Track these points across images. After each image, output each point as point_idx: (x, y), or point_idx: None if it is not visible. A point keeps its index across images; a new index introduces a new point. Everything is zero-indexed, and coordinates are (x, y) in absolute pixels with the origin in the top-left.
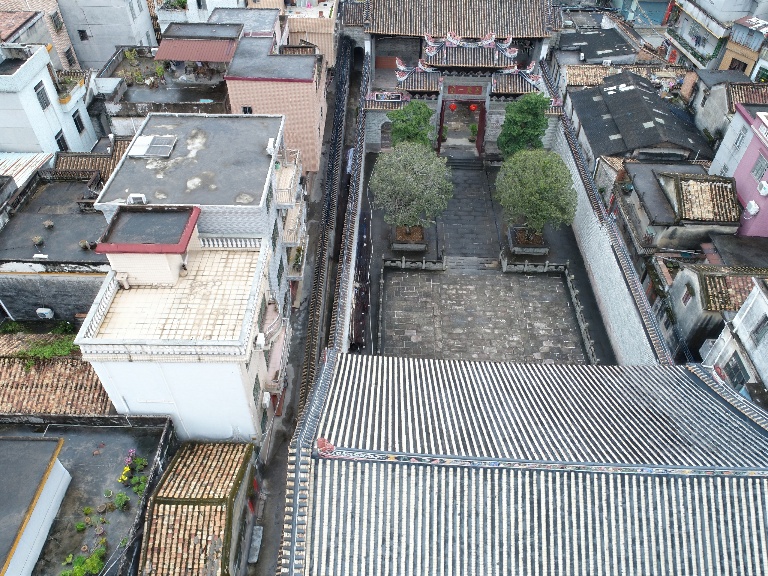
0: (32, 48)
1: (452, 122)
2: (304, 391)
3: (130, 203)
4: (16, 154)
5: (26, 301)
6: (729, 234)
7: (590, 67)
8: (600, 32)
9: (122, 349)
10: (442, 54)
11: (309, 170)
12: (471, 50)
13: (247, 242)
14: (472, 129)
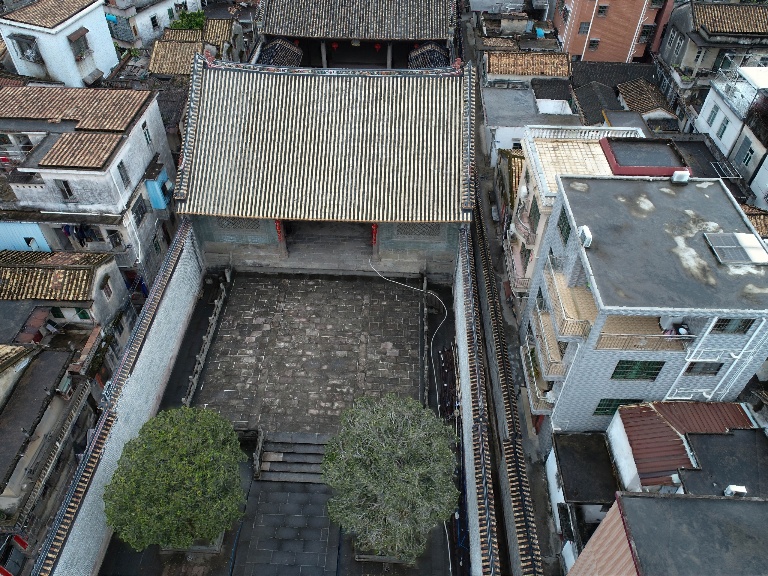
0: None
1: None
2: None
3: None
4: None
5: None
6: None
7: None
8: None
9: (608, 135)
10: None
11: None
12: None
13: None
14: None
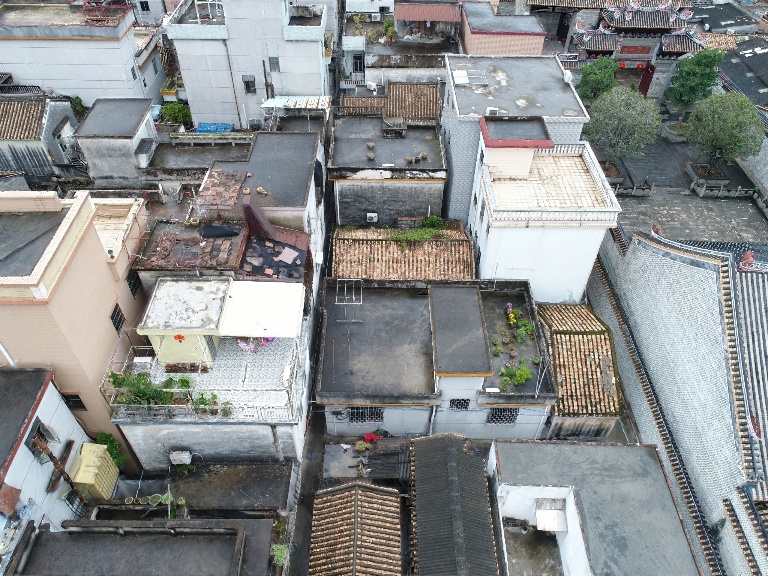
0: (315, 7)
1: None
2: (603, 272)
3: None
4: (301, 97)
5: (358, 207)
6: None
7: (721, 35)
8: (717, 6)
9: (525, 216)
10: (624, 17)
11: None
12: (649, 14)
13: (569, 148)
14: (631, 87)
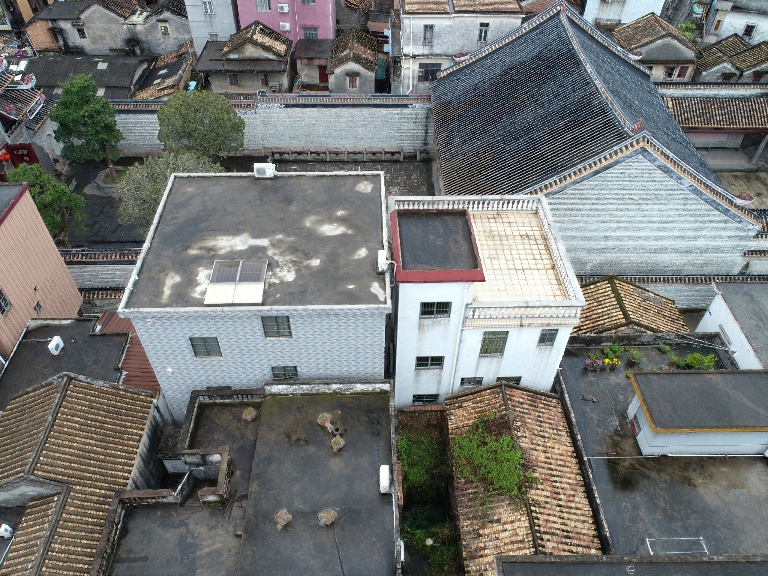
0: None
1: None
2: None
3: (387, 270)
4: None
5: None
6: (292, 52)
7: None
8: None
9: None
10: None
11: (78, 309)
12: None
13: None
14: None
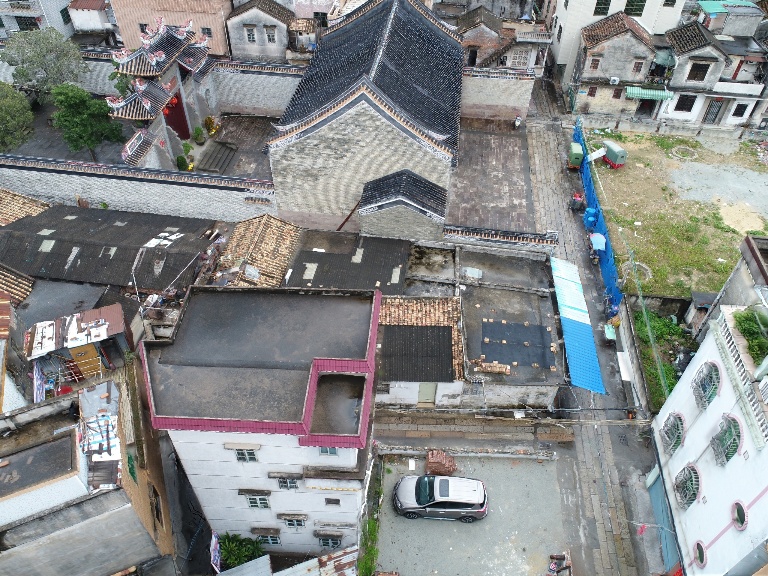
0: None
1: (256, 165)
2: None
3: None
4: None
5: None
6: None
7: None
8: (390, 283)
9: None
10: None
11: None
12: None
13: None
14: None
